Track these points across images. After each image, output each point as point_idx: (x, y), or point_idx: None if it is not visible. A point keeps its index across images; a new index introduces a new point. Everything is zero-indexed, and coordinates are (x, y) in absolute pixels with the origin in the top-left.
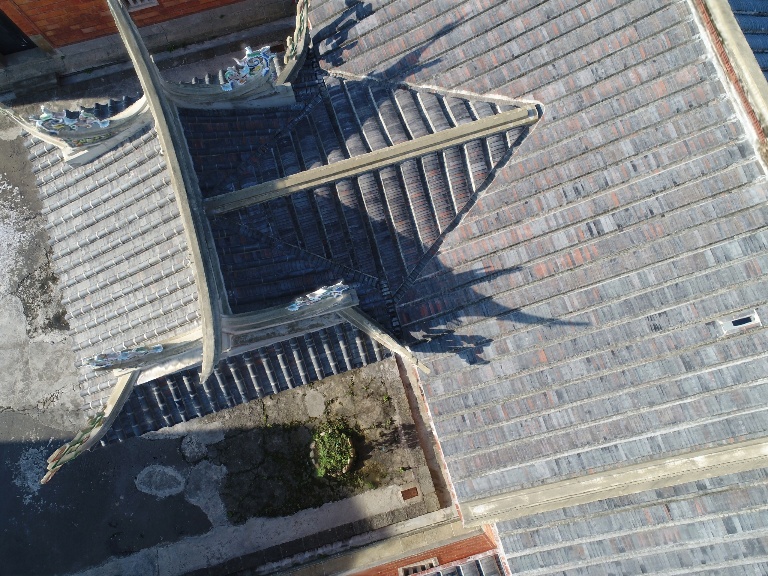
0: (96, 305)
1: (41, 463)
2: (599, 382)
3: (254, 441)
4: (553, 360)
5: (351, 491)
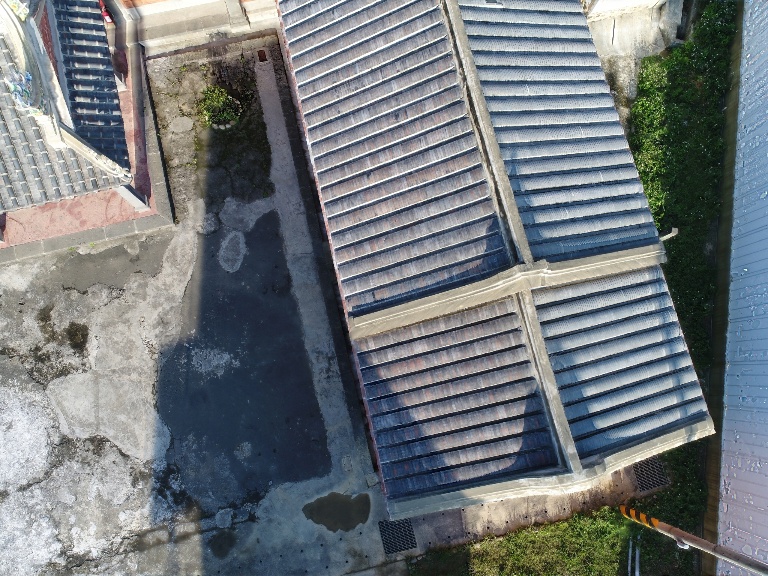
0: (3, 169)
1: (206, 353)
2: None
3: (207, 175)
4: None
5: (256, 100)
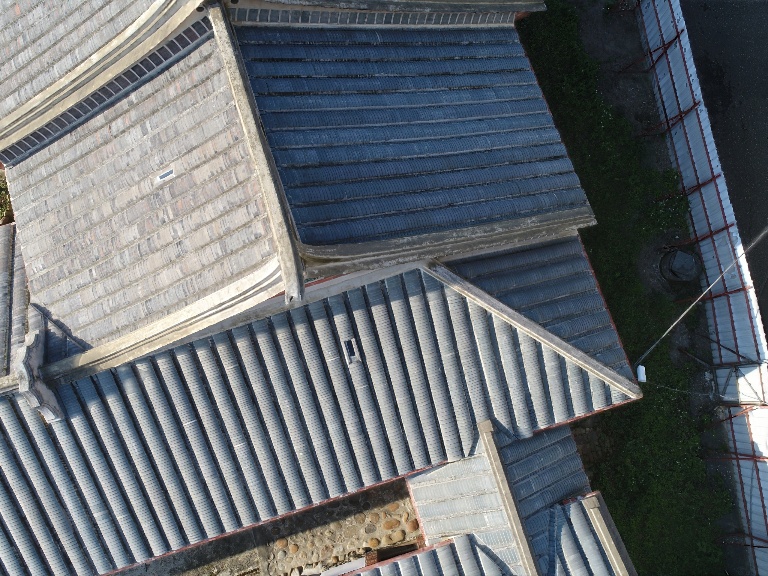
0: None
1: None
2: (47, 18)
3: None
4: (24, 11)
5: None
